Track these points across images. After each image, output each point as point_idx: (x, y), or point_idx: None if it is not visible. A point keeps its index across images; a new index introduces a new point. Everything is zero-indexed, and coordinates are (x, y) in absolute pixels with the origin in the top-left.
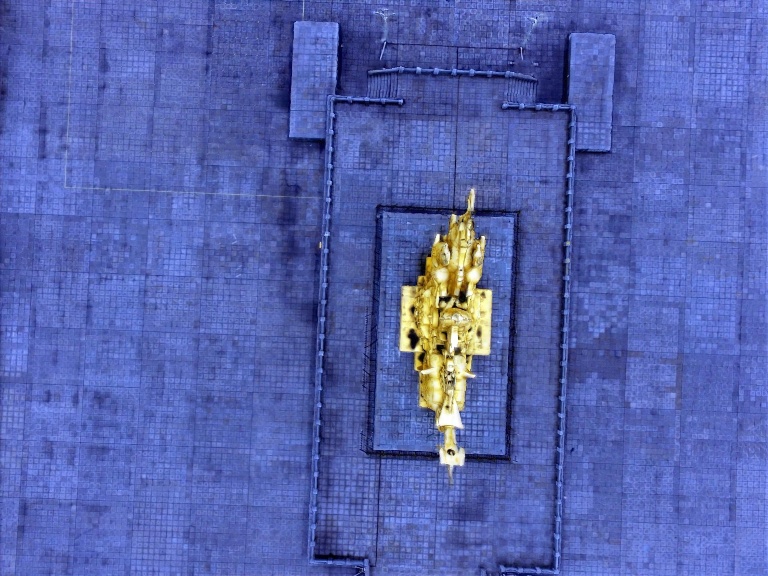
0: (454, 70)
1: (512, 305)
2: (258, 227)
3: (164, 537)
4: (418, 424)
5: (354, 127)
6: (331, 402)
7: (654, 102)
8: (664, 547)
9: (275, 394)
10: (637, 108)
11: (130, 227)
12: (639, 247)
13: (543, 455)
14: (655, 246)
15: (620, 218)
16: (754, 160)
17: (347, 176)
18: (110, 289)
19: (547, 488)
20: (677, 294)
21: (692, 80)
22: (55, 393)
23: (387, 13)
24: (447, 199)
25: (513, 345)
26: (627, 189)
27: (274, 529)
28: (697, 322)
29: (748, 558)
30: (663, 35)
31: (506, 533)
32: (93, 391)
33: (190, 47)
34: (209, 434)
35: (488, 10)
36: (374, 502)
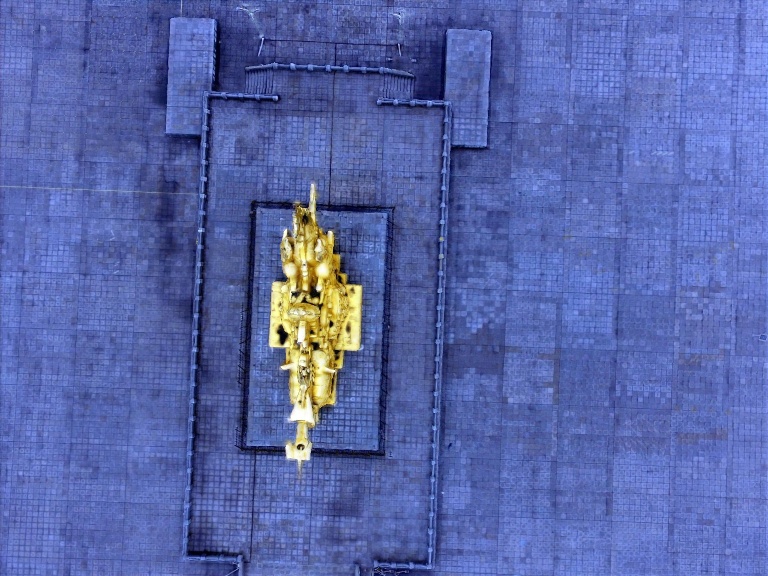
0: (328, 66)
1: (387, 301)
2: (136, 223)
3: (41, 534)
4: None
5: (229, 123)
6: (206, 398)
7: (531, 98)
8: (541, 542)
9: (153, 390)
10: (515, 104)
11: (7, 224)
12: (517, 243)
13: (418, 450)
14: (532, 242)
15: (498, 214)
16: (631, 156)
17: (222, 172)
18: None
19: (422, 483)
20: (554, 289)
21: (569, 76)
22: None
23: (265, 9)
24: (322, 195)
25: (388, 341)
26: (505, 185)
27: (151, 526)
28: (574, 317)
29: (624, 552)
30: (540, 31)
31: (381, 528)
32: None
33: (67, 43)
34: (86, 431)
35: (366, 6)
36: (249, 498)
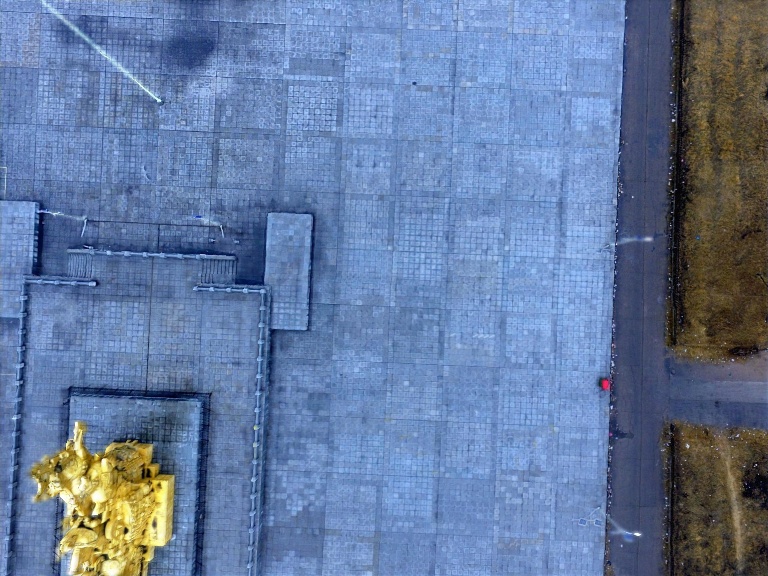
0: (144, 254)
1: (202, 488)
2: None
3: None
4: None
5: (48, 308)
6: None
7: (353, 280)
8: None
9: None
10: (337, 286)
11: None
12: (337, 425)
13: None
14: (353, 424)
15: (319, 396)
16: (452, 338)
17: (40, 357)
18: None
19: None
20: (375, 472)
21: (391, 258)
22: None
23: (89, 190)
24: (140, 380)
25: (203, 527)
26: (326, 367)
27: None
28: (394, 500)
29: None
30: (363, 213)
31: None
32: None
33: None
34: None
35: (189, 188)
36: None
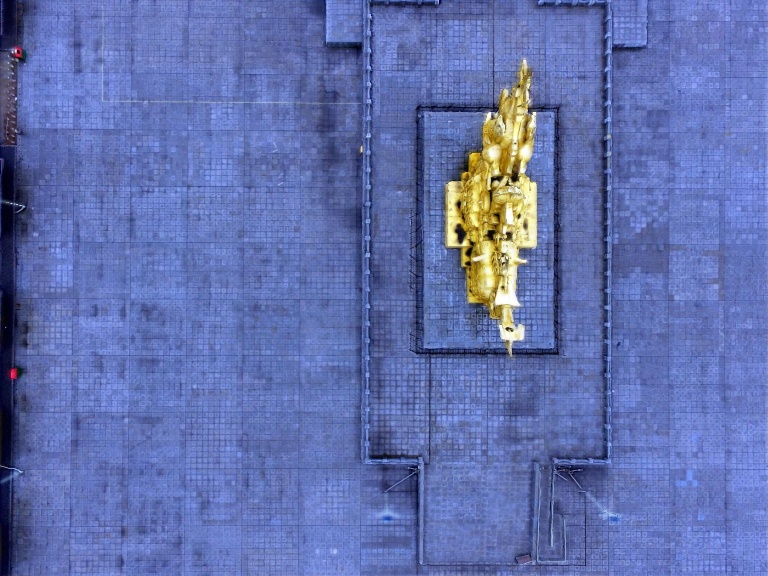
0: None
1: (555, 201)
2: (298, 135)
3: (217, 446)
4: (467, 321)
5: (391, 29)
6: (379, 304)
7: None
8: (712, 436)
9: (322, 300)
10: (671, 2)
11: (170, 139)
12: (678, 141)
13: (591, 348)
14: (693, 139)
15: (658, 113)
16: None
17: (386, 78)
18: (152, 202)
19: (596, 380)
20: (717, 186)
21: None
22: (102, 307)
23: None
24: (486, 98)
25: (557, 240)
26: (664, 83)
27: (326, 434)
28: (737, 213)
29: None
30: None
31: (557, 426)
32: (140, 304)
33: None
34: (258, 342)
35: None
36: (425, 401)
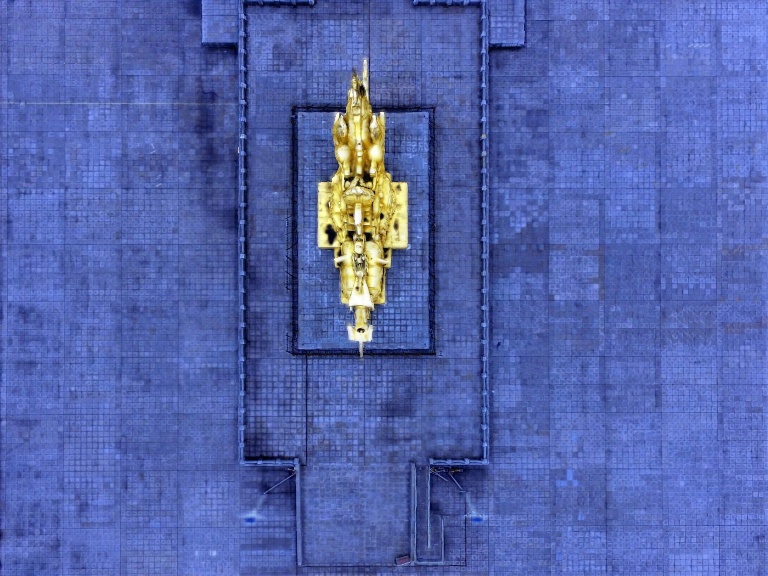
0: None
1: (431, 201)
2: (176, 136)
3: (96, 448)
4: (341, 321)
5: (266, 29)
6: (255, 305)
7: None
8: (592, 436)
9: (201, 302)
10: (550, 1)
11: (47, 141)
12: (557, 140)
13: (468, 348)
14: (573, 139)
15: (537, 112)
16: (668, 49)
17: (261, 79)
18: (30, 204)
19: (473, 381)
20: (596, 186)
21: None
22: None
23: None
24: None
25: (434, 241)
26: (543, 83)
27: (205, 435)
28: (617, 213)
29: (675, 442)
30: None
31: (434, 427)
32: (17, 306)
33: None
34: (136, 344)
35: None
36: (302, 402)
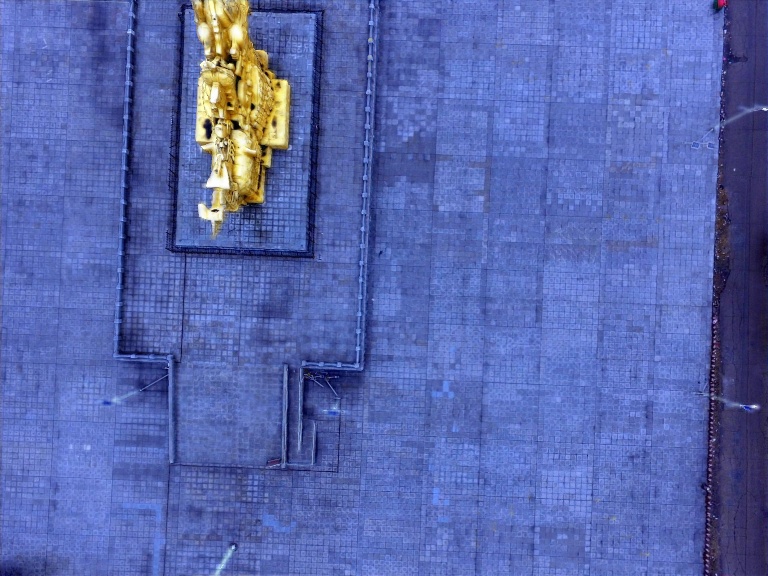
0: None
1: (316, 104)
2: (68, 32)
3: None
4: None
5: None
6: (137, 201)
7: None
8: (470, 348)
9: (86, 198)
10: None
11: None
12: (448, 51)
13: (347, 253)
14: (464, 49)
15: (429, 22)
16: None
17: None
18: None
19: (351, 286)
20: (486, 97)
21: None
22: None
23: None
24: None
25: (317, 144)
26: None
27: (85, 331)
28: (506, 125)
29: (553, 359)
30: None
31: (310, 330)
32: None
33: None
34: (21, 237)
35: None
36: (179, 300)
